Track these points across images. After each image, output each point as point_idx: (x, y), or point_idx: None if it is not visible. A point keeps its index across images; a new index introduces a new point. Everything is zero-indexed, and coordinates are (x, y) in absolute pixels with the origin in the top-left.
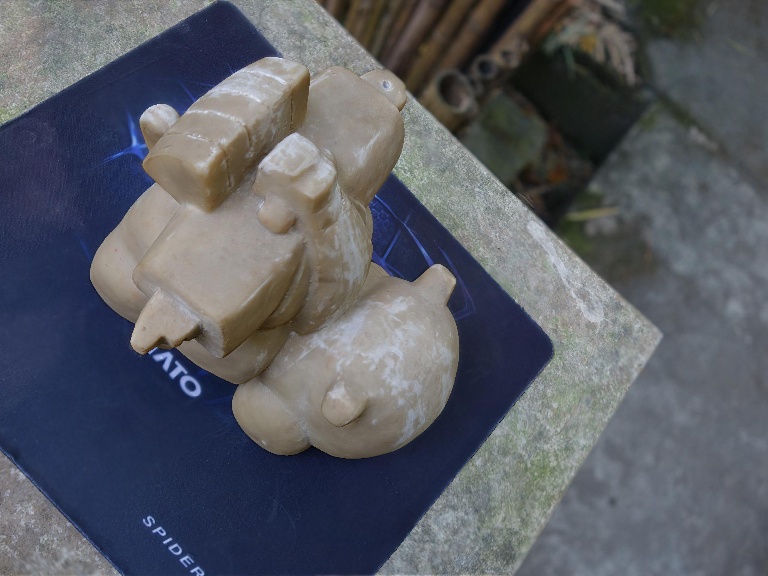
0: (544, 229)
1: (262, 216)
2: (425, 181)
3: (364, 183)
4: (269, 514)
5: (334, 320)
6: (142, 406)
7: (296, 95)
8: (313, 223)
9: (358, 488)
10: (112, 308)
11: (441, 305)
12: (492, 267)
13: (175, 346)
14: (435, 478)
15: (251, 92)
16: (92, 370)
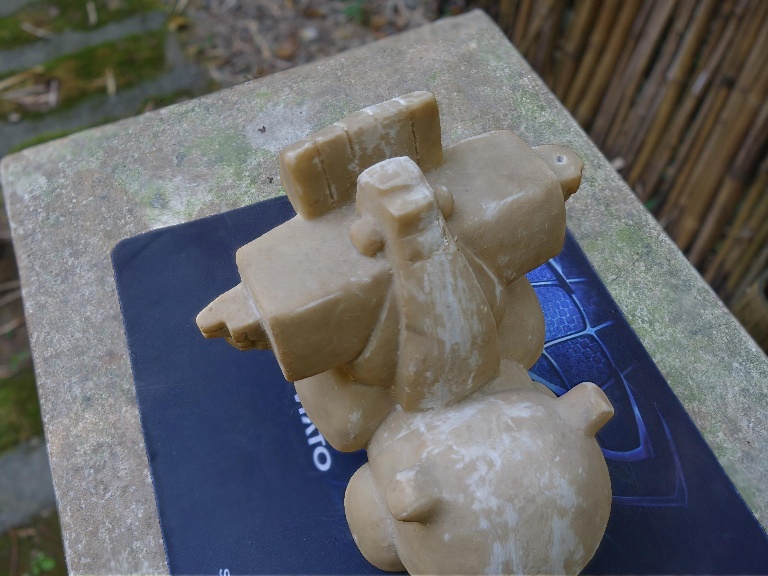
0: None
1: (350, 231)
2: (666, 338)
3: (492, 242)
4: None
5: (442, 403)
6: (271, 459)
7: (418, 122)
8: (399, 250)
9: None
10: None
11: (580, 431)
12: (731, 461)
13: (235, 339)
14: None
15: (370, 108)
16: (246, 409)
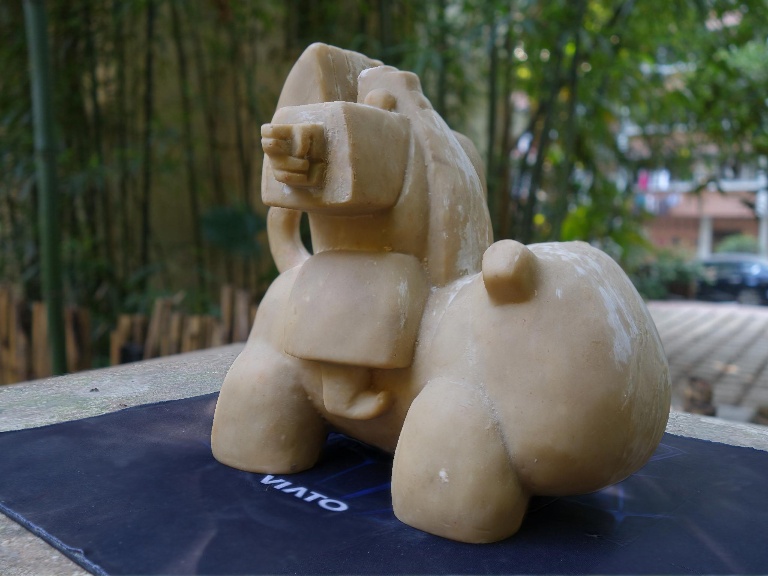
0: (723, 420)
1: (367, 98)
2: None
3: None
4: None
5: (473, 264)
6: (268, 518)
7: None
8: (410, 98)
9: (630, 573)
10: (234, 455)
11: None
12: None
13: (302, 143)
14: (759, 560)
15: None
16: (205, 498)
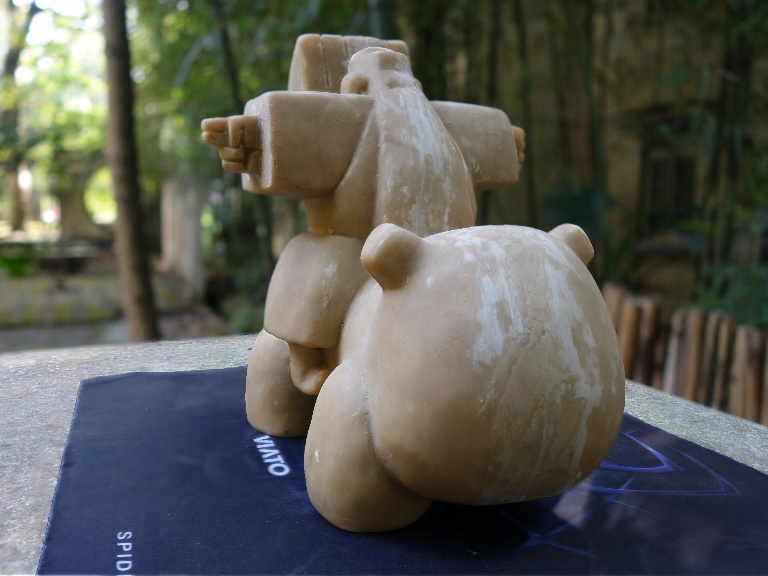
0: None
1: None
2: (665, 423)
3: (455, 122)
4: (281, 575)
5: None
6: (215, 468)
7: None
8: (379, 79)
9: None
10: None
11: None
12: None
13: (233, 134)
14: None
15: None
16: (194, 444)
